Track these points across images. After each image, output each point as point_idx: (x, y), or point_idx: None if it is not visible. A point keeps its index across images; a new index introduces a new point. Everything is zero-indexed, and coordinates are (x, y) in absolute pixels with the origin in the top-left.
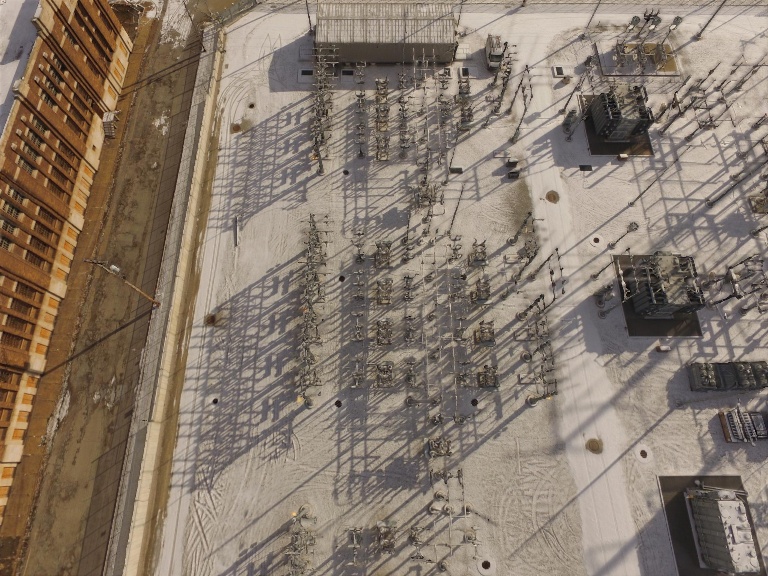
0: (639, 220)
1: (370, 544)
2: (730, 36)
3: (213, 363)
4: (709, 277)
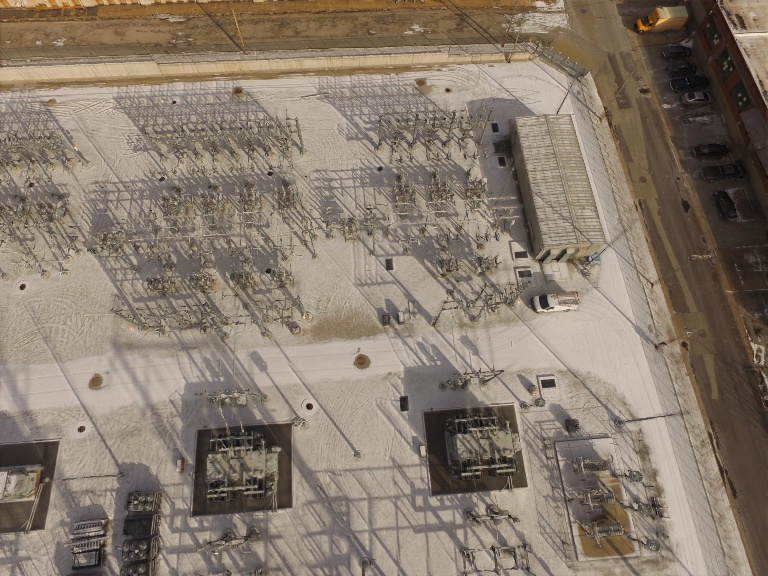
0: (337, 461)
1: None
2: None
3: (203, 97)
4: None
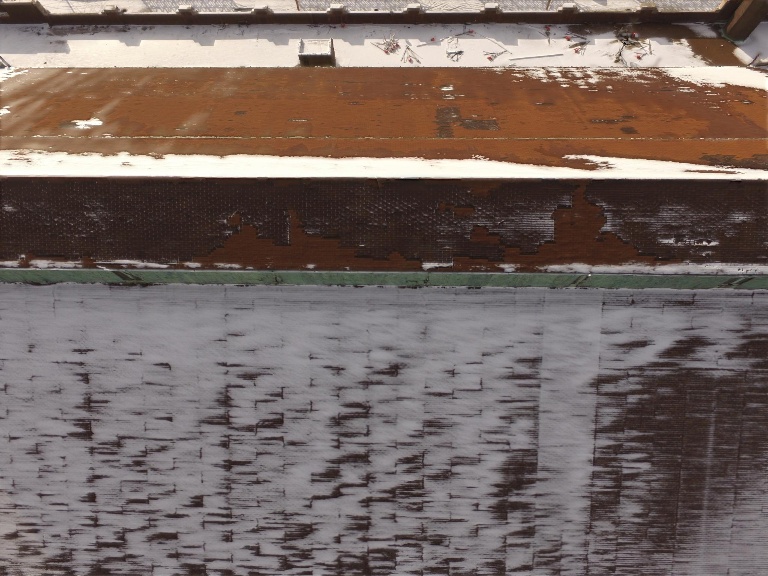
0: None
1: None
2: None
3: None
4: None
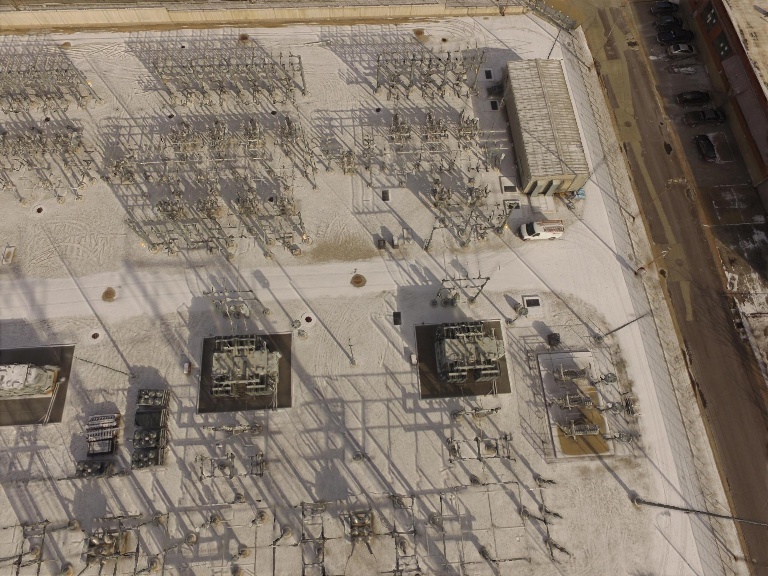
0: (334, 368)
1: None
2: (655, 558)
3: (211, 42)
4: None
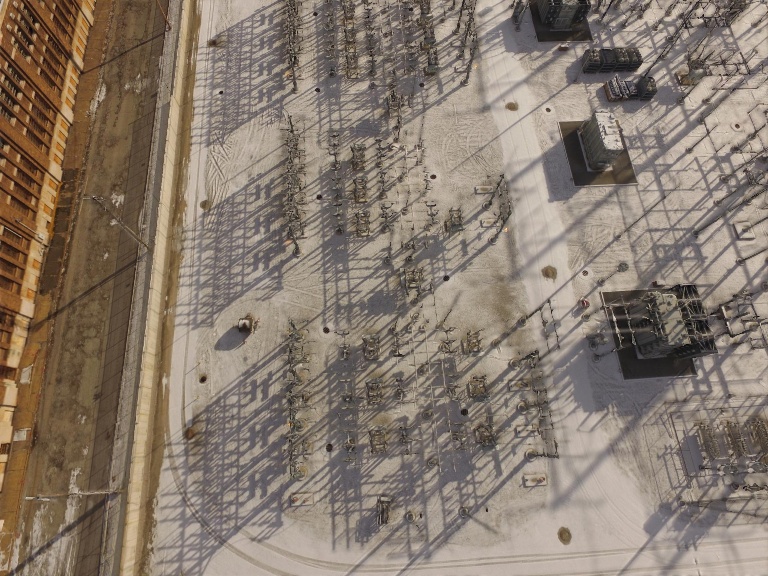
0: None
1: (347, 169)
2: None
3: (217, 69)
4: (598, 1)
